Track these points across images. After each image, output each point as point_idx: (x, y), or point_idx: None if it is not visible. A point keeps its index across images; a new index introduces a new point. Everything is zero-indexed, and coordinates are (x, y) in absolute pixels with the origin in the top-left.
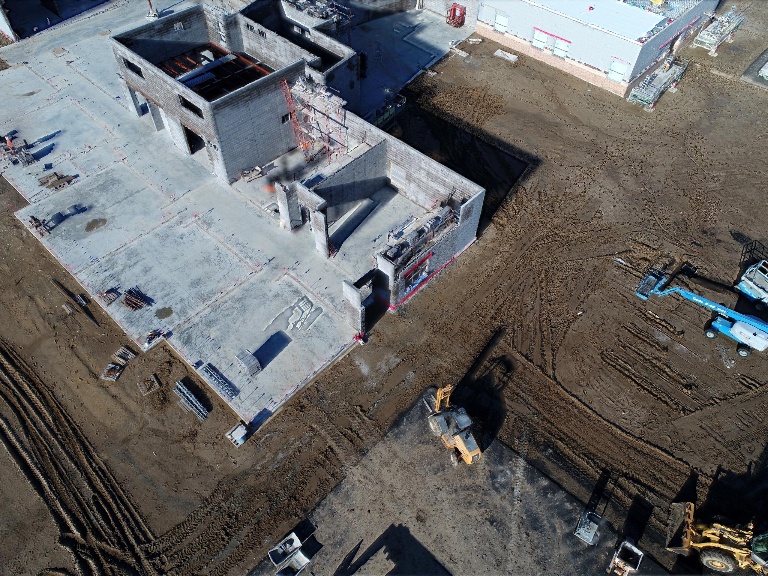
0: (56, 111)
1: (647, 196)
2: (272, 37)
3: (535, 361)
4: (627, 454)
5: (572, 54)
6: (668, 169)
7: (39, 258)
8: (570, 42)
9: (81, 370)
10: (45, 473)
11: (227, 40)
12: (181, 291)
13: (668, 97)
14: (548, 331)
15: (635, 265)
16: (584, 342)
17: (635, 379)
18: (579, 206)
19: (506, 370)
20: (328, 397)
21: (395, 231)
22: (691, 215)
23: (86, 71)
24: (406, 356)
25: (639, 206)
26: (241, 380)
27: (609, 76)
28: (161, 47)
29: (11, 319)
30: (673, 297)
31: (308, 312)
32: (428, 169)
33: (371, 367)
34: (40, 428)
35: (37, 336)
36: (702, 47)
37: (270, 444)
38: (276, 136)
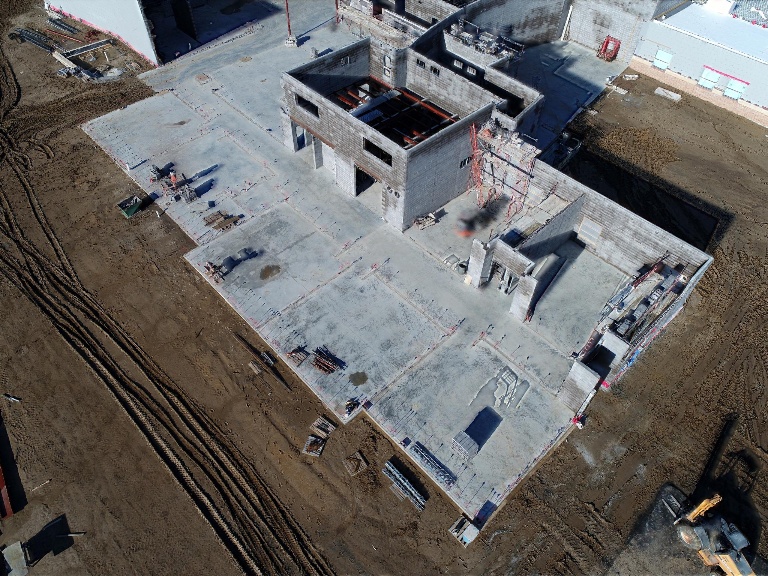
0: (209, 143)
1: None
2: (447, 75)
3: None
4: None
5: (748, 96)
6: None
7: (216, 307)
8: (748, 83)
9: (280, 441)
10: (260, 564)
11: (393, 75)
12: (372, 353)
13: None
14: None
15: None
16: None
17: None
18: None
19: (749, 469)
20: (554, 490)
21: (614, 301)
22: None
23: (233, 100)
24: (632, 445)
25: None
26: (456, 464)
27: None
28: (326, 82)
29: (197, 376)
30: None
31: (514, 386)
32: (636, 229)
33: (595, 456)
34: (246, 508)
35: (227, 398)
36: None
37: (500, 545)
38: (451, 181)
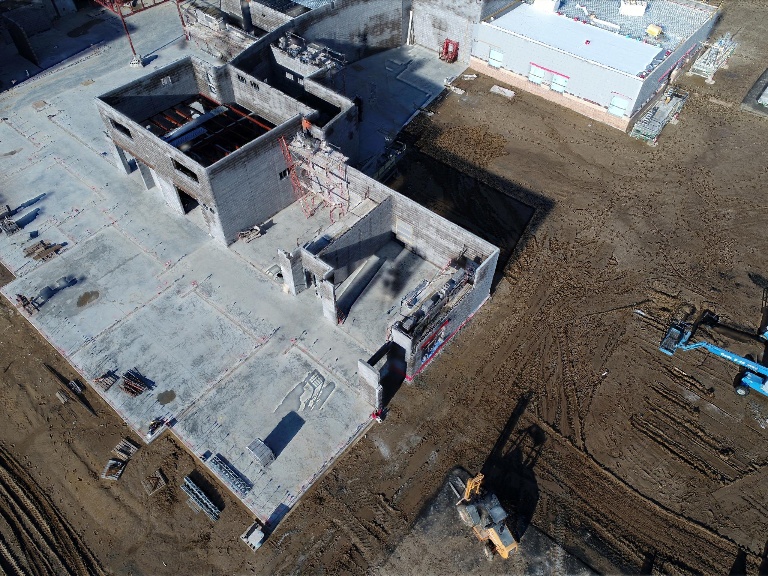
0: (39, 171)
1: (660, 239)
2: (265, 89)
3: (563, 432)
4: (669, 534)
5: (570, 89)
6: (678, 208)
7: (28, 340)
8: (568, 77)
9: (79, 469)
10: None
11: (217, 92)
12: (183, 371)
13: (670, 130)
14: (573, 396)
15: (656, 316)
16: (612, 407)
17: (669, 446)
18: (592, 253)
19: (534, 444)
20: (348, 486)
21: (408, 298)
22: (707, 258)
23: (69, 126)
24: (427, 433)
25: (653, 250)
26: (254, 472)
27: (610, 111)
28: (149, 103)
29: (1, 412)
30: (698, 350)
31: (320, 388)
32: (437, 226)
33: (391, 448)
34: (37, 540)
35: (30, 431)
36: (699, 75)
37: (289, 545)
38: (274, 193)
